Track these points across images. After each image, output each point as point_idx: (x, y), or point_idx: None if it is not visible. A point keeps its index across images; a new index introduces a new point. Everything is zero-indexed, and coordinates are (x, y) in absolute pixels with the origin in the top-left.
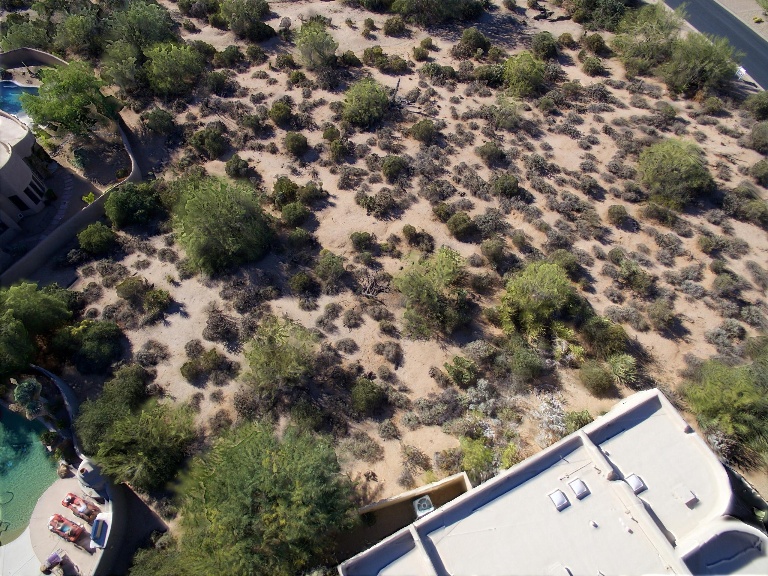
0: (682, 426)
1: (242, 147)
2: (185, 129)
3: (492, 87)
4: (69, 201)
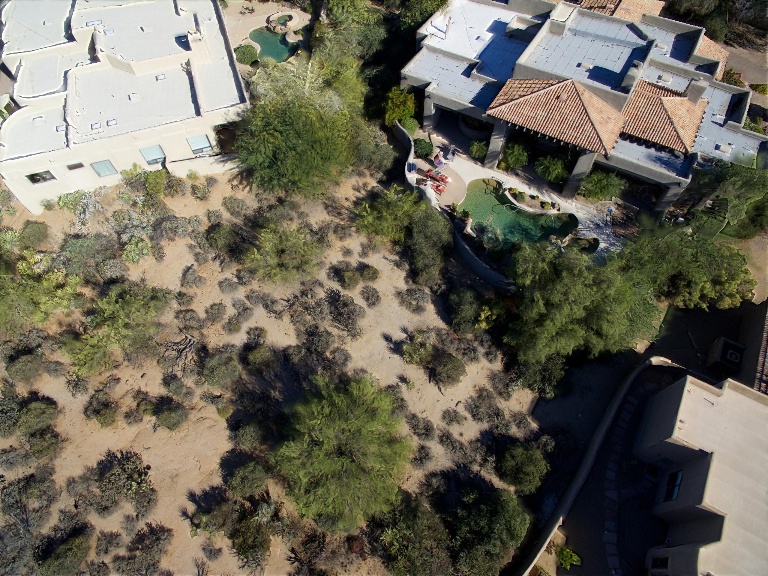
0: None
1: None
2: None
3: None
4: None
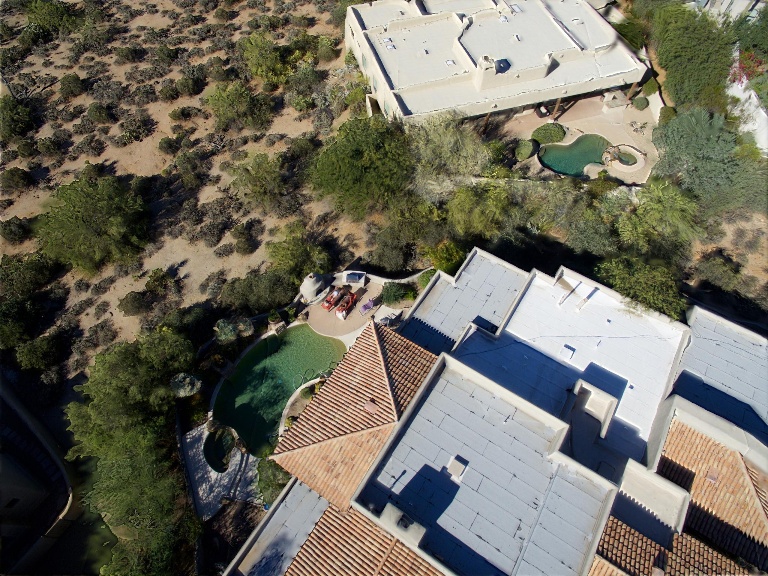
0: (368, 6)
1: None
2: None
3: (48, 42)
4: None
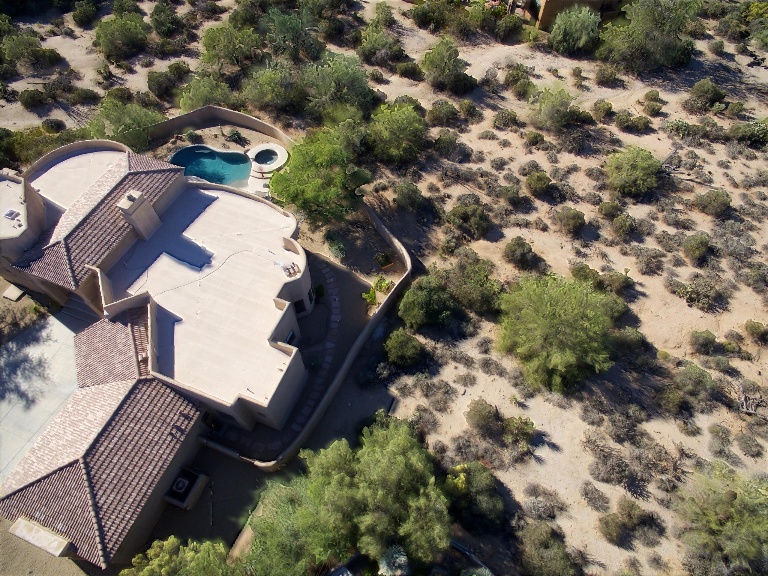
0: None
1: (506, 223)
2: (434, 203)
3: (752, 148)
4: (339, 297)
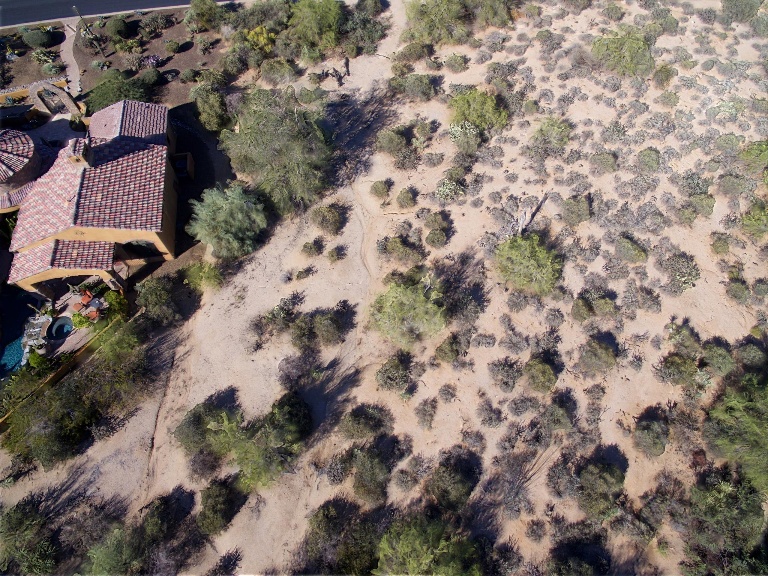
0: None
1: None
2: (570, 538)
3: None
4: None
